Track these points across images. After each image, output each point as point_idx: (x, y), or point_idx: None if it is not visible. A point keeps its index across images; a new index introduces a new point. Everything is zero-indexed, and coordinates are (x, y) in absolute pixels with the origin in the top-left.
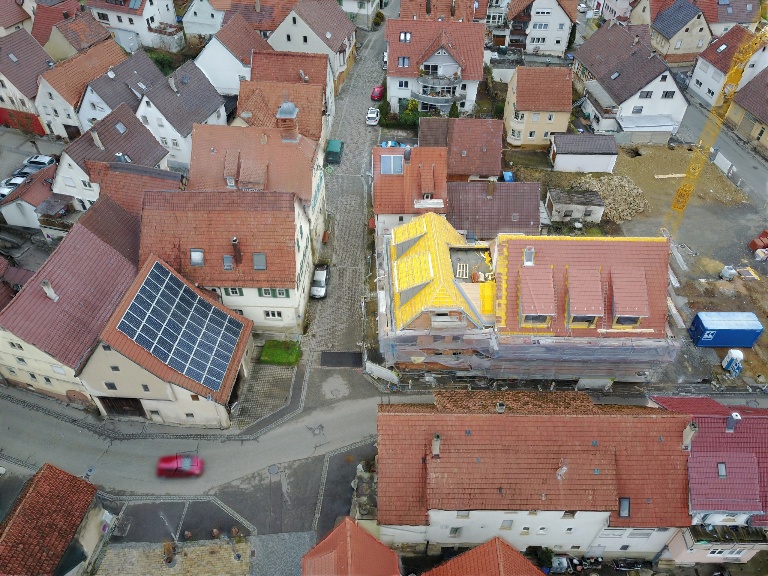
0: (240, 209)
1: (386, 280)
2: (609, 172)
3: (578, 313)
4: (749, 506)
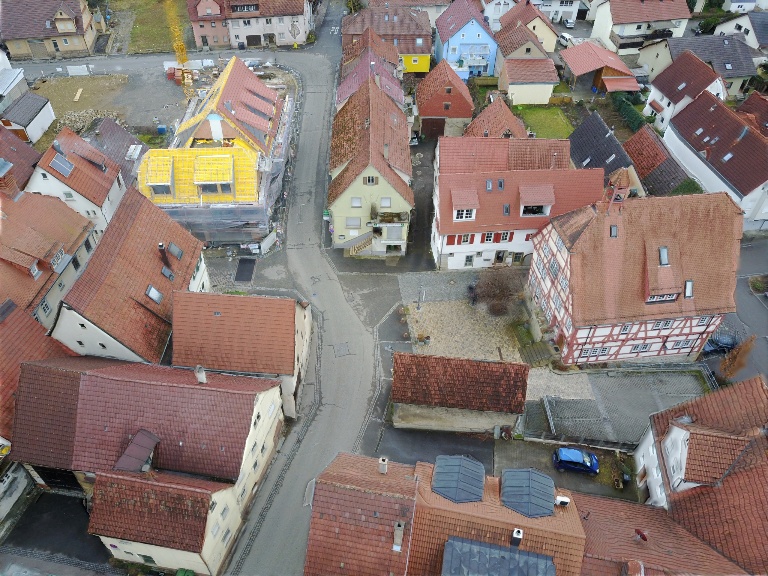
0: (128, 229)
1: (197, 205)
2: (55, 119)
3: (271, 113)
4: (401, 92)
